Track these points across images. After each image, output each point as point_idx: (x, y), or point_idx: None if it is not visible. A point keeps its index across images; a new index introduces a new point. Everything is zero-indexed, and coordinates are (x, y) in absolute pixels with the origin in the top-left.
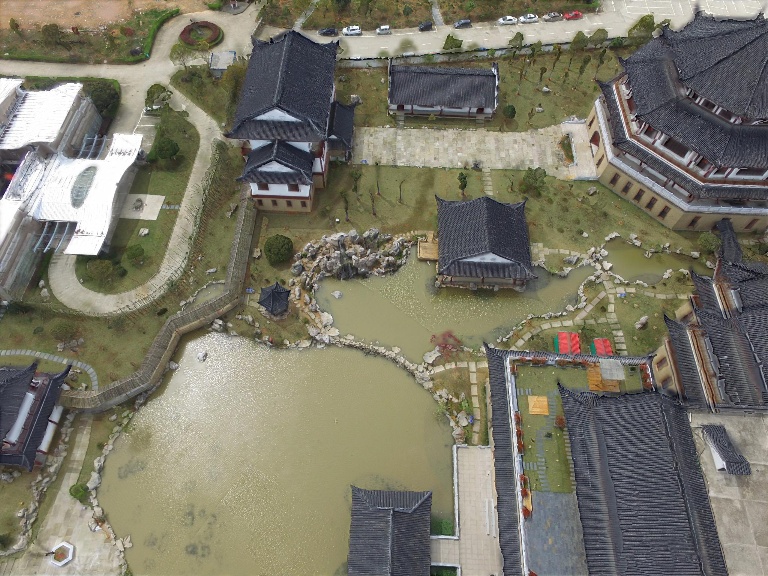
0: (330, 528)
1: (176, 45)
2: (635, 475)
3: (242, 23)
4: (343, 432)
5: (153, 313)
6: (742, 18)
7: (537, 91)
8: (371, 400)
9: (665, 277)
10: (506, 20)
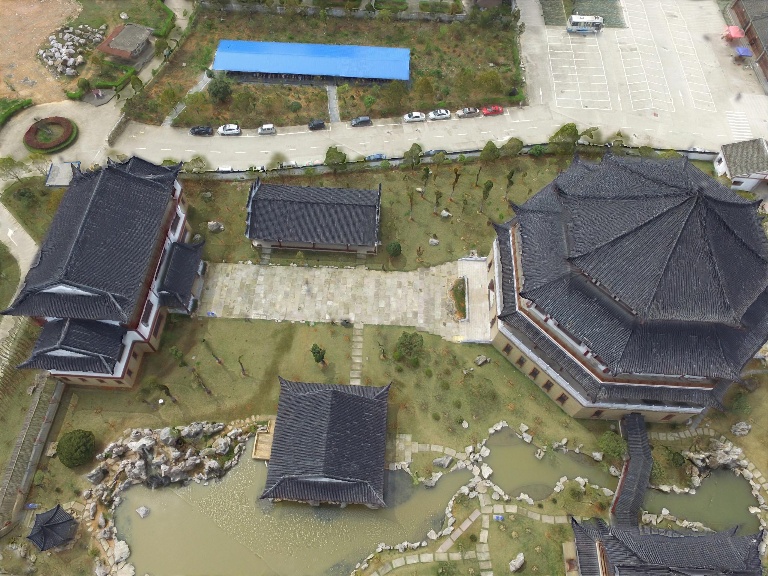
0: None
1: (0, 160)
2: None
3: (103, 117)
4: None
5: None
6: (689, 115)
7: (434, 215)
8: None
9: (556, 490)
10: (412, 117)
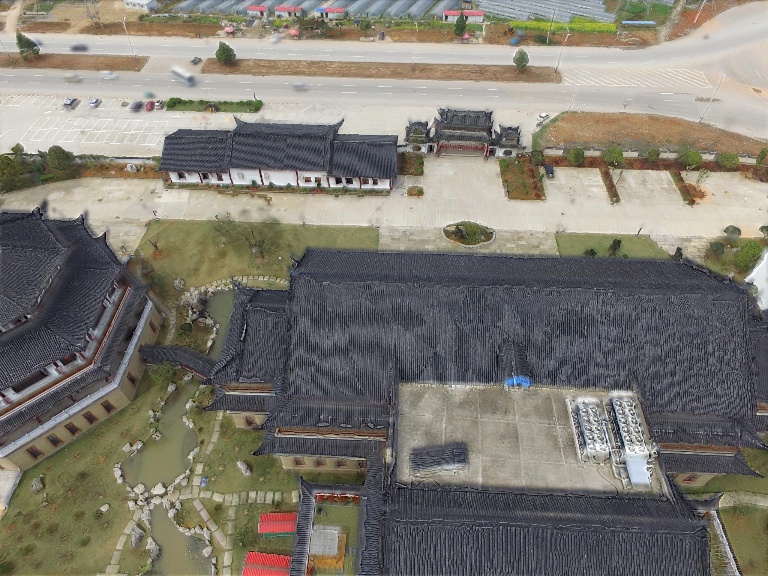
0: None
1: None
2: (471, 568)
3: None
4: None
5: None
6: None
7: None
8: None
9: (192, 426)
10: None
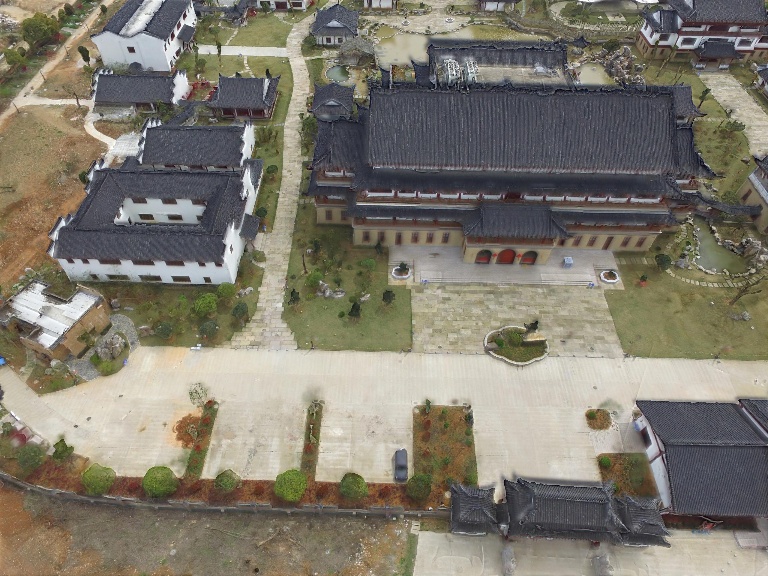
0: None
1: None
2: None
3: None
4: None
5: None
6: None
7: None
8: None
9: None
10: None
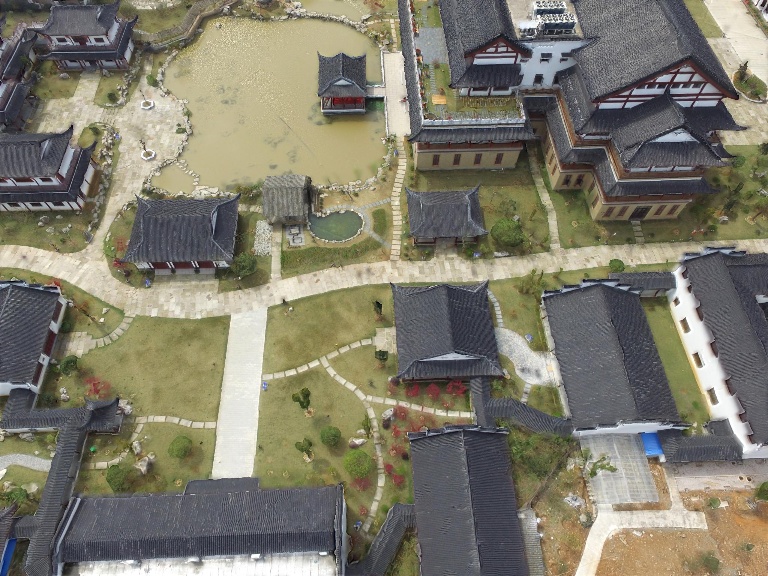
0: (308, 91)
1: None
2: None
3: None
4: (313, 61)
5: (183, 7)
6: None
7: None
8: (330, 49)
9: None
10: None
